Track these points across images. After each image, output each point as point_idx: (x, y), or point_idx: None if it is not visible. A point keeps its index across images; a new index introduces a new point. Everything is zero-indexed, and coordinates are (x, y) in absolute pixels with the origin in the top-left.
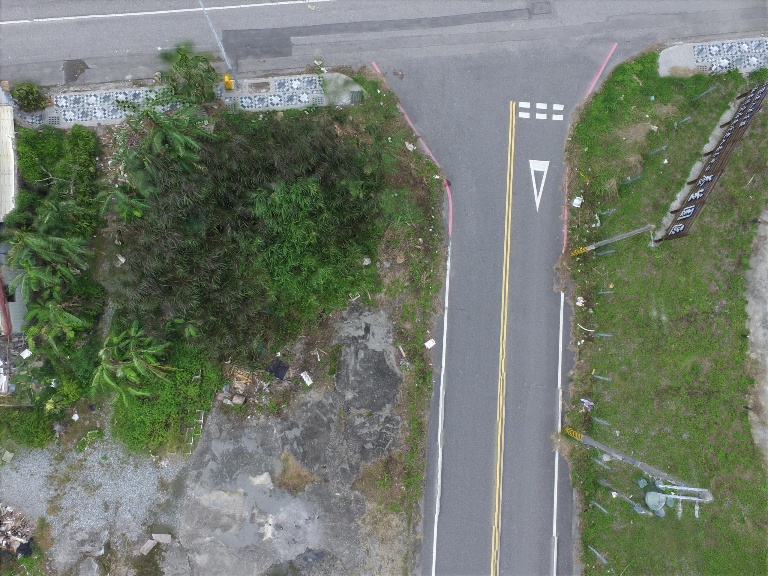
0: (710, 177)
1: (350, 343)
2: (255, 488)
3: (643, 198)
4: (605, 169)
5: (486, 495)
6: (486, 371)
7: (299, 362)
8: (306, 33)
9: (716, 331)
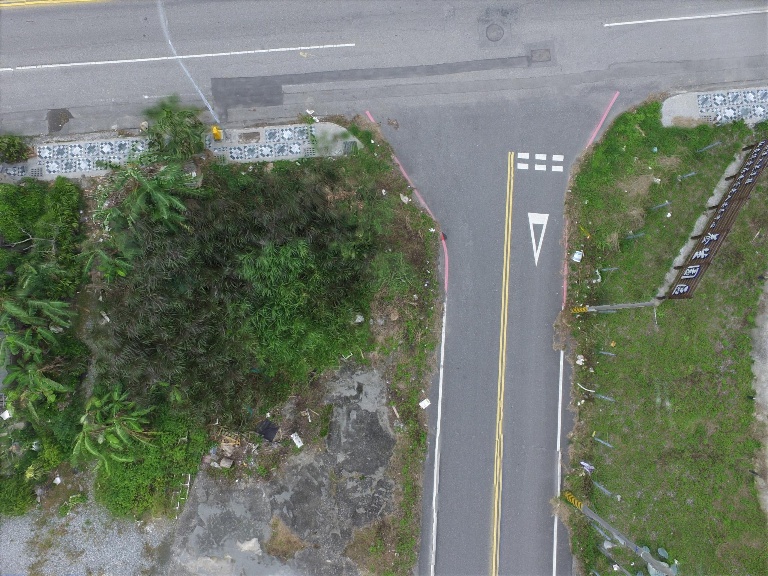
0: (715, 236)
1: (342, 403)
2: (243, 555)
3: (645, 253)
4: (606, 223)
5: (482, 562)
6: (483, 432)
7: (289, 423)
8: (298, 81)
9: (721, 392)
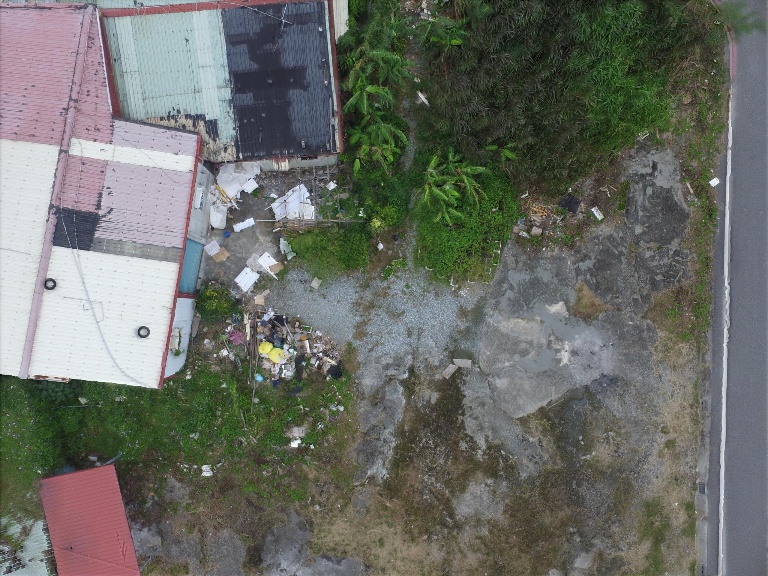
0: None
1: (638, 180)
2: (551, 316)
3: None
4: None
5: None
6: None
7: (590, 198)
8: None
9: None
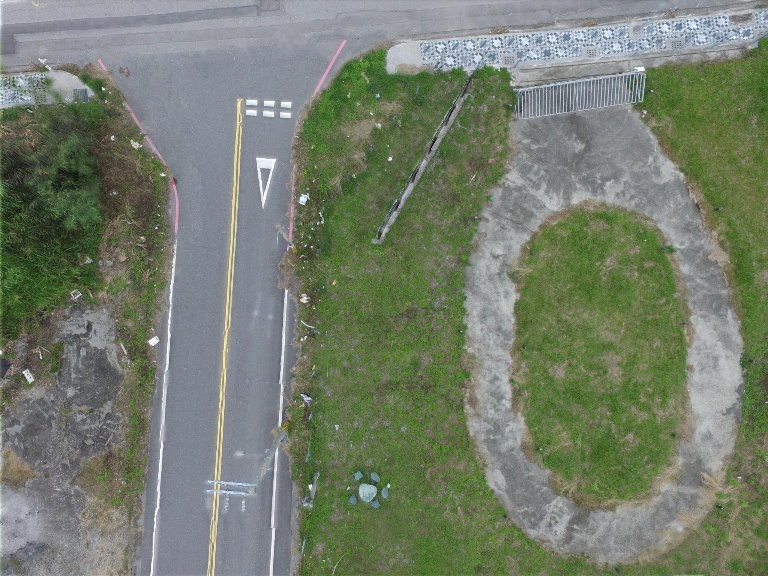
0: None
1: (72, 341)
2: None
3: (367, 196)
4: (329, 167)
5: (206, 489)
6: (209, 367)
7: (21, 360)
8: (30, 30)
9: (435, 326)
